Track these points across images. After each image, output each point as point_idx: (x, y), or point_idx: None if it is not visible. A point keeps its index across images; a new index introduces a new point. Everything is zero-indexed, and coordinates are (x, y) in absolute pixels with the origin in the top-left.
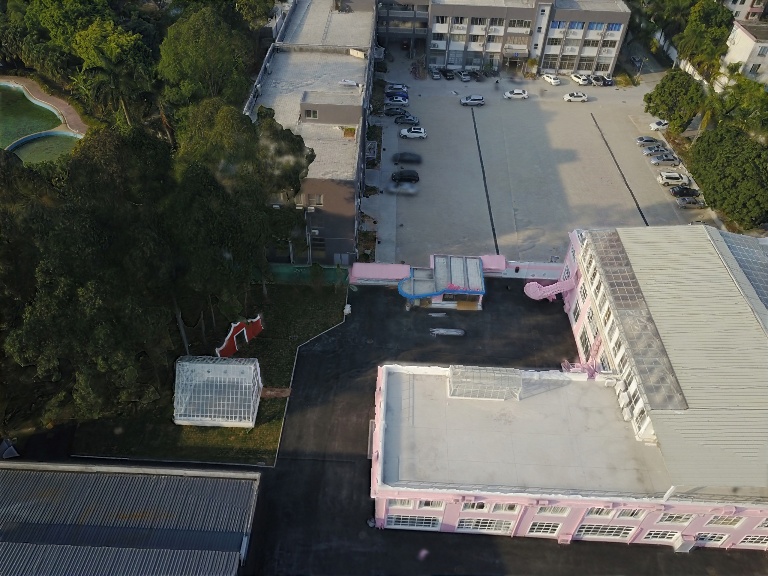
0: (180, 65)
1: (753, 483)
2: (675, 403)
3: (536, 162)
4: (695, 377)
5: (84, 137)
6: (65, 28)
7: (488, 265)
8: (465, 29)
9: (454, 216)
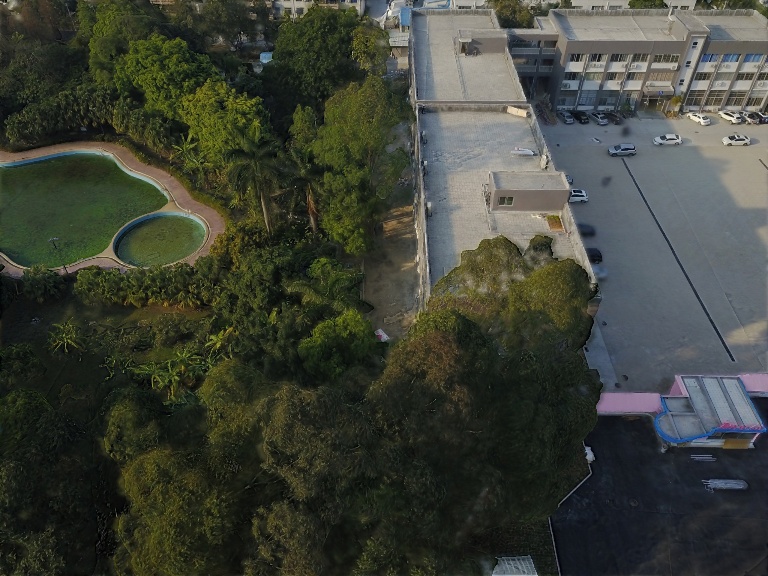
0: (346, 149)
1: None
2: None
3: (725, 228)
4: None
5: (226, 234)
6: (168, 91)
7: (750, 387)
8: (603, 67)
9: (660, 307)
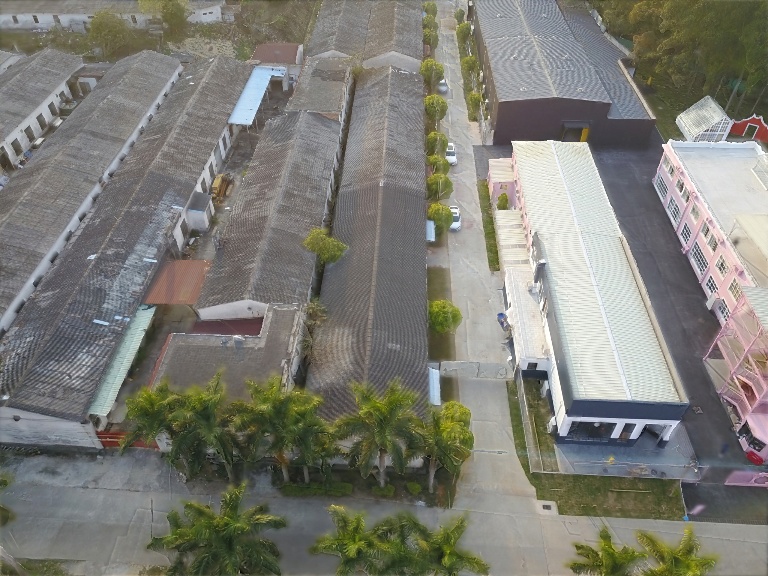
0: None
1: (756, 241)
2: None
3: None
4: None
5: None
6: None
7: None
8: None
9: None
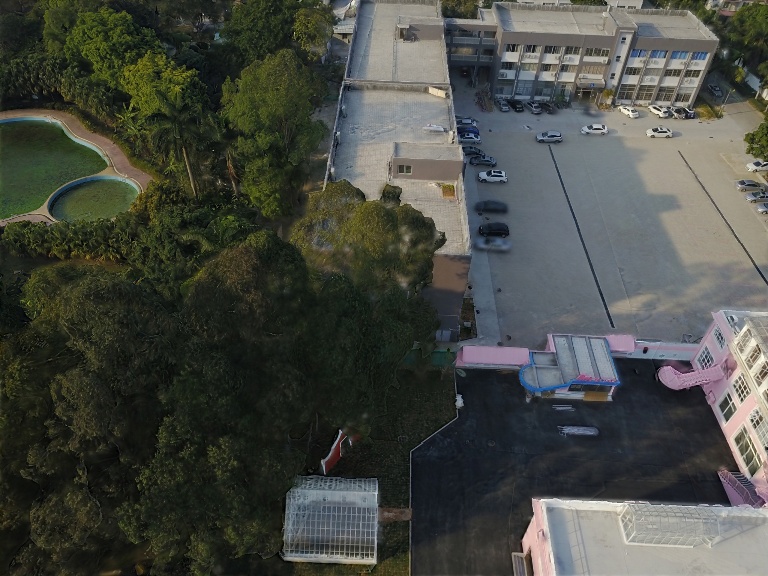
0: (257, 114)
1: None
2: None
3: (632, 210)
4: None
5: (145, 192)
6: (111, 61)
7: (615, 347)
8: (537, 58)
9: (555, 278)
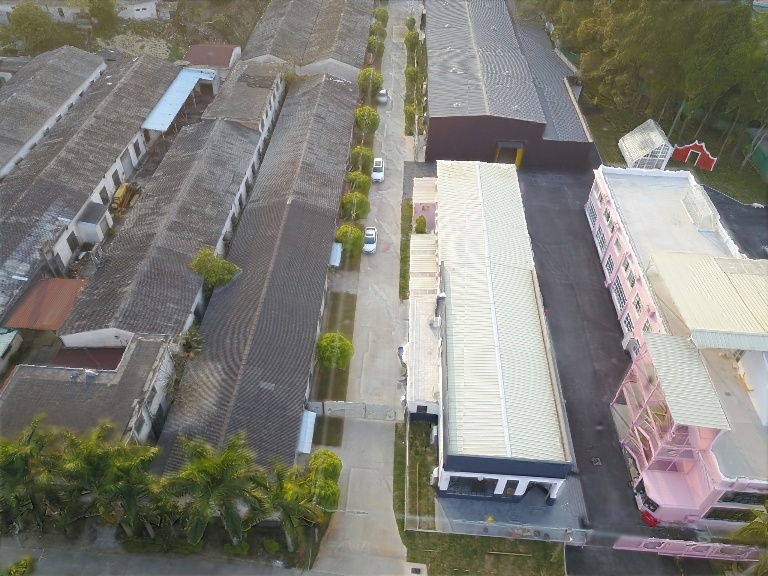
0: None
1: (667, 282)
2: (728, 270)
3: None
4: (764, 284)
5: None
6: None
7: None
8: None
9: None
